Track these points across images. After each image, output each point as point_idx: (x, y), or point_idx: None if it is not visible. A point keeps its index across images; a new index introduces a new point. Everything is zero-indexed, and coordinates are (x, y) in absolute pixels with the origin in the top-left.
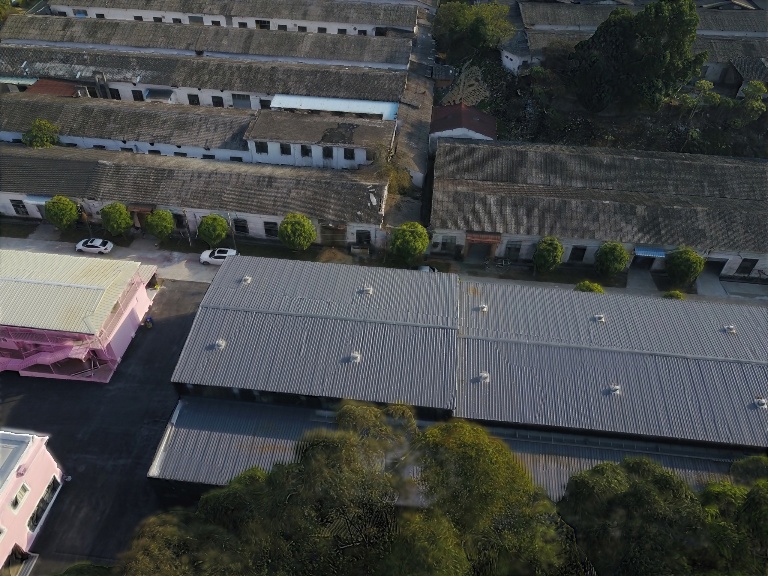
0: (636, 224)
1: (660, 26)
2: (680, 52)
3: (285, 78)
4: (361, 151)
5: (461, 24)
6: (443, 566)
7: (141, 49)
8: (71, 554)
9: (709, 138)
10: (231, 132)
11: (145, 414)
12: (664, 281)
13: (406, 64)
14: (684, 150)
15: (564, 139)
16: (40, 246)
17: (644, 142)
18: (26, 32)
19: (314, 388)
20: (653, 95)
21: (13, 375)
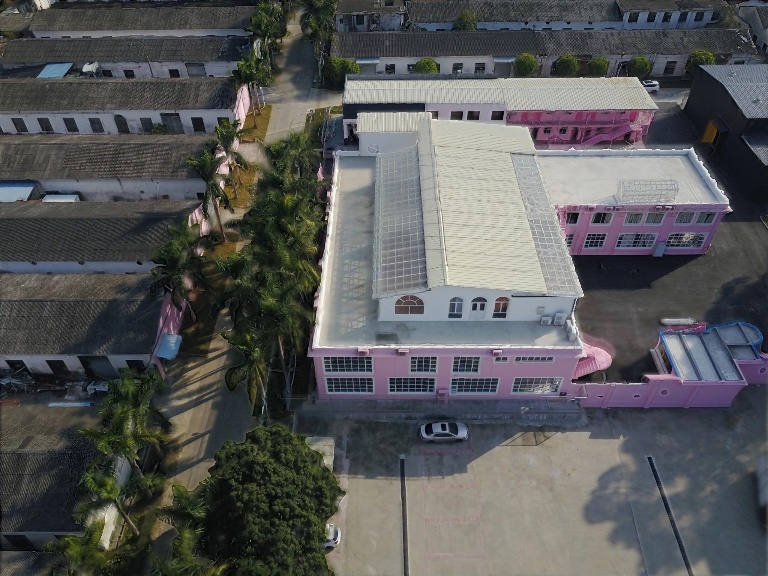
0: None
1: None
2: None
3: None
4: (710, 13)
5: None
6: None
7: None
8: None
9: None
10: (604, 10)
11: None
12: None
13: None
14: None
15: None
16: None
17: None
18: None
19: None
20: None
21: None
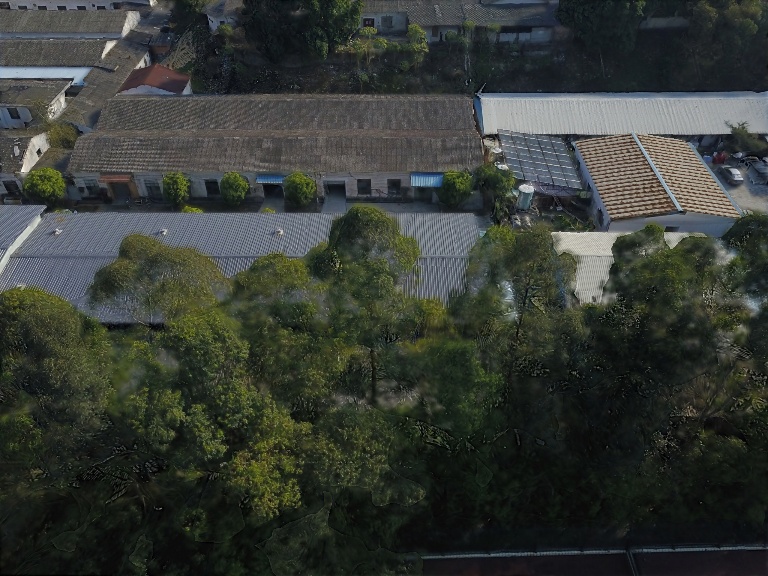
0: (259, 155)
1: None
2: None
3: None
4: (23, 109)
5: None
6: None
7: None
8: None
9: (385, 81)
10: None
11: None
12: (294, 206)
13: (120, 33)
14: None
15: (253, 91)
16: None
17: (328, 89)
18: None
19: None
20: (315, 42)
21: None
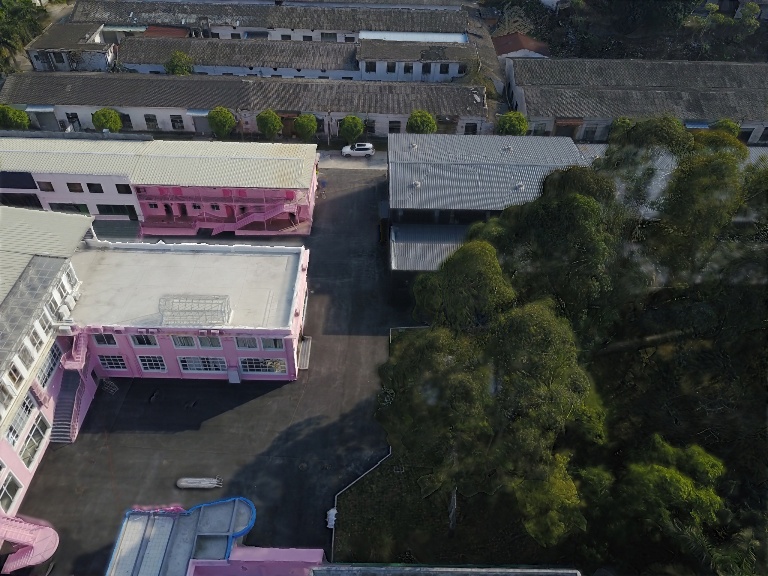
0: (684, 105)
1: None
2: None
3: (365, 18)
4: (455, 65)
5: None
6: (735, 164)
7: (226, 1)
8: (335, 335)
9: (716, 51)
10: (341, 57)
11: (349, 251)
12: None
13: (460, 6)
14: None
15: (603, 58)
16: None
17: (666, 57)
18: None
19: (498, 205)
20: (675, 15)
21: (230, 235)
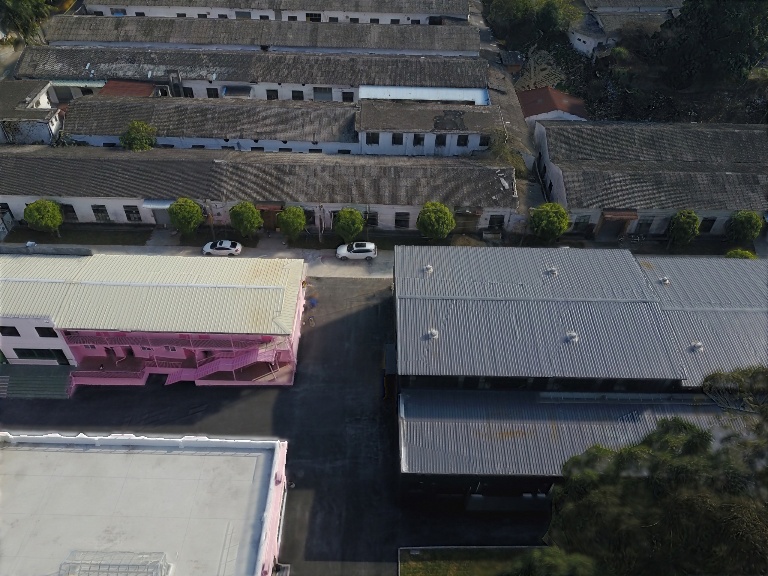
0: (762, 193)
1: (747, 2)
2: (766, 27)
3: (366, 69)
4: (475, 137)
5: (521, 10)
6: None
7: (202, 46)
8: (323, 561)
9: None
10: (337, 125)
11: (344, 413)
12: None
13: (478, 51)
14: (763, 122)
15: (649, 117)
16: (163, 252)
17: (724, 116)
18: (76, 33)
19: (545, 369)
20: (740, 70)
21: (188, 385)
